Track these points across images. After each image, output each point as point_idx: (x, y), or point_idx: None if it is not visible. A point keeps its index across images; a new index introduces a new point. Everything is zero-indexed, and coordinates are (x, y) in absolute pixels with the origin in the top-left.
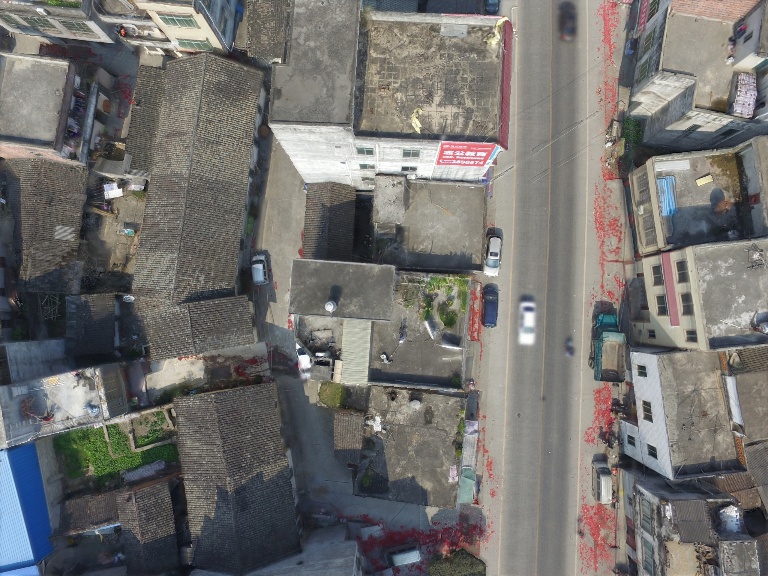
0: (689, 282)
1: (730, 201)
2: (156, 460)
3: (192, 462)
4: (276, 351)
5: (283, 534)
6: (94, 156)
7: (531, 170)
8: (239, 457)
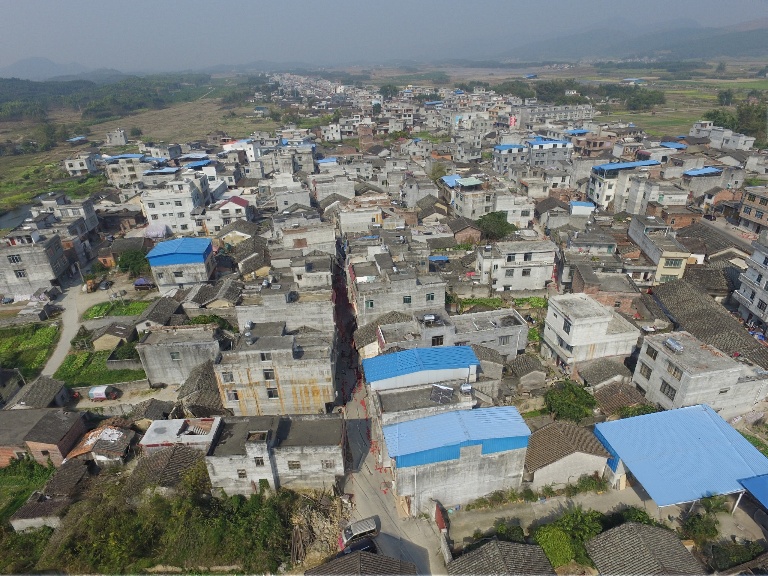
0: None
1: None
2: None
3: None
4: None
5: None
6: None
7: None
8: None
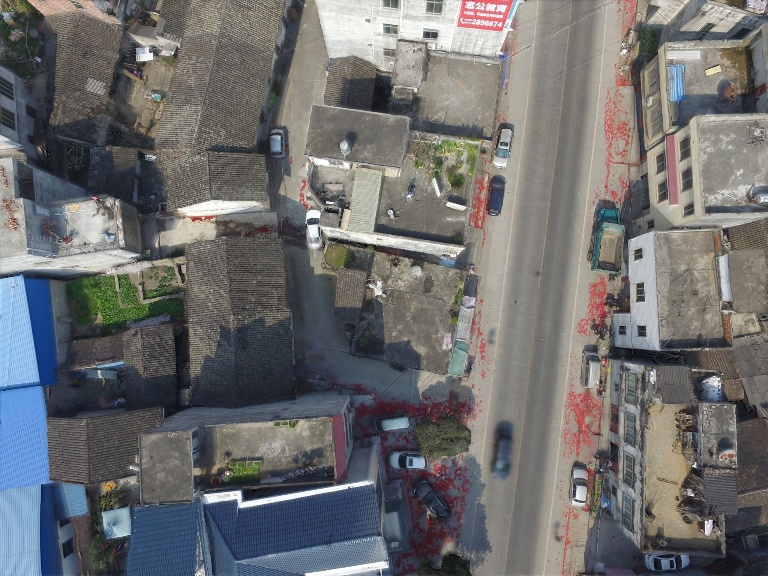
0: (690, 156)
1: (736, 92)
2: (162, 313)
3: (198, 305)
4: (286, 222)
5: (279, 379)
6: (129, 21)
7: (546, 71)
8: (244, 299)
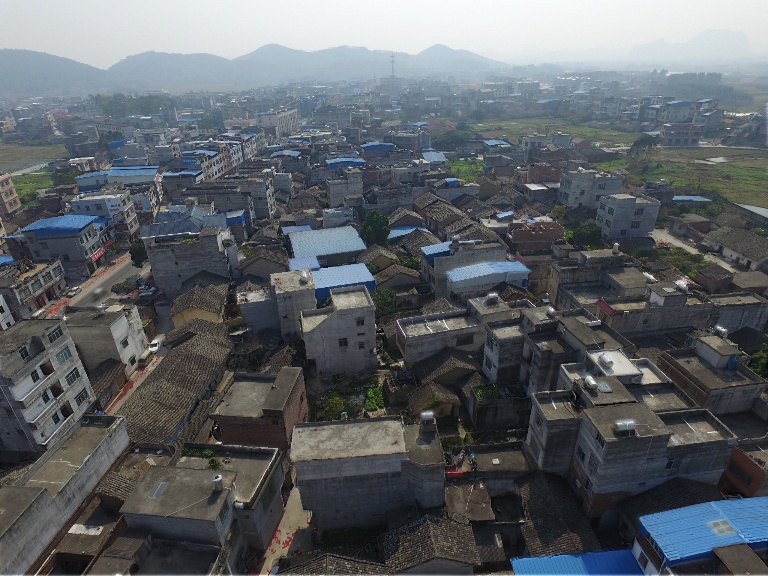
0: None
1: None
2: None
3: None
4: None
5: None
6: None
7: None
8: None
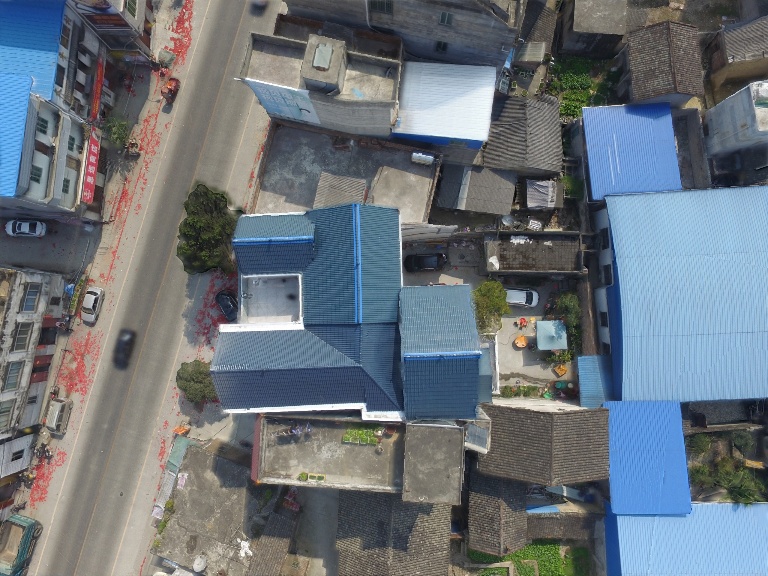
0: None
1: None
2: None
3: (434, 571)
4: None
5: None
6: None
7: None
8: (377, 575)
